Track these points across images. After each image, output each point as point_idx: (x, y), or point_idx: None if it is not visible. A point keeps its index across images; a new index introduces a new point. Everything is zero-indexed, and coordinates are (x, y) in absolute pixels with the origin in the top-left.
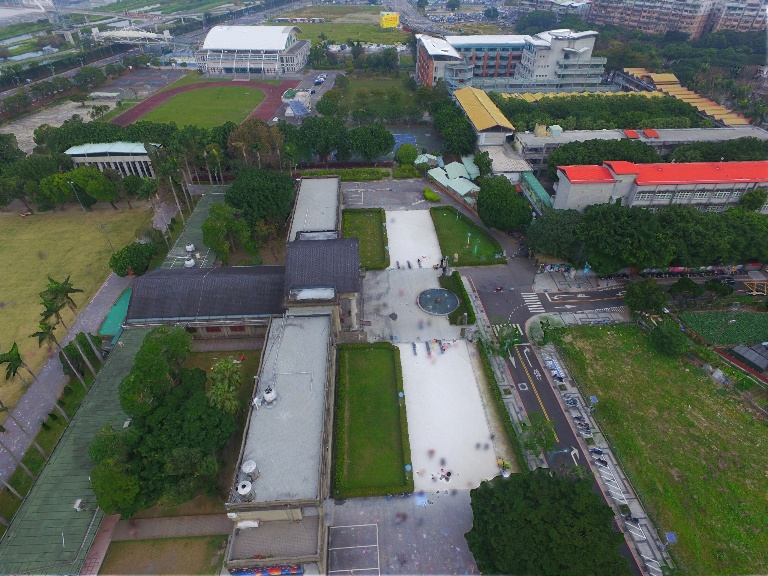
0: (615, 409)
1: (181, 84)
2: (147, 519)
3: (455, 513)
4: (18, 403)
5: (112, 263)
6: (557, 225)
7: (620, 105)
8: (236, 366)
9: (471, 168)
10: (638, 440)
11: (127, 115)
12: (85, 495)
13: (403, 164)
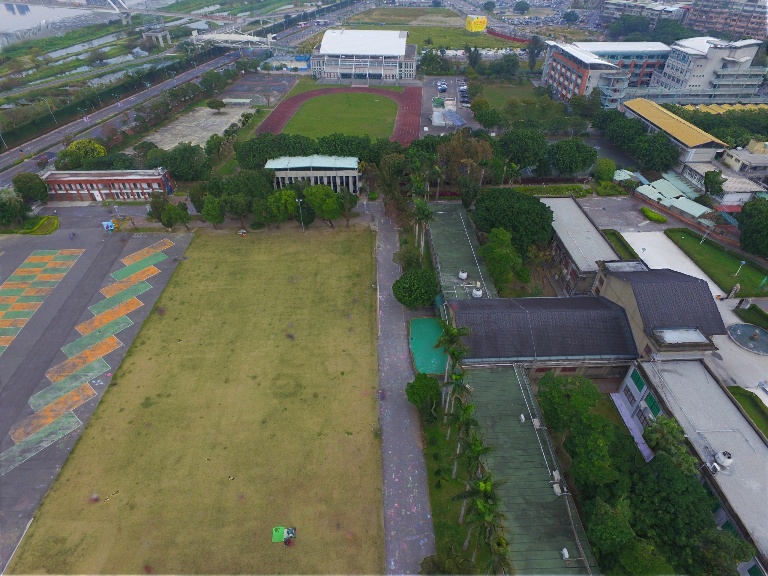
0: None
1: (302, 90)
2: None
3: None
4: (383, 454)
5: (403, 293)
6: None
7: None
8: None
9: (681, 186)
10: None
11: (269, 123)
12: (569, 575)
13: (602, 180)
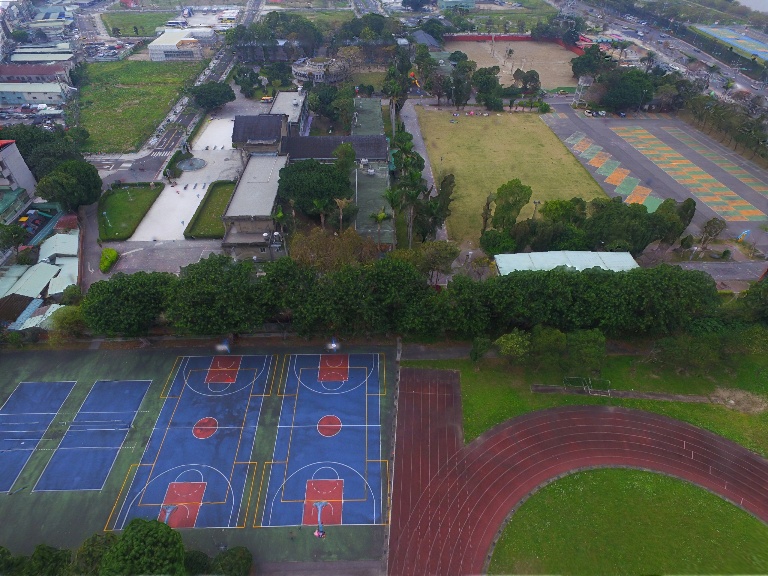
0: None
1: None
2: None
3: None
4: (422, 135)
5: None
6: None
7: None
8: (309, 101)
9: None
10: None
11: None
12: None
13: None
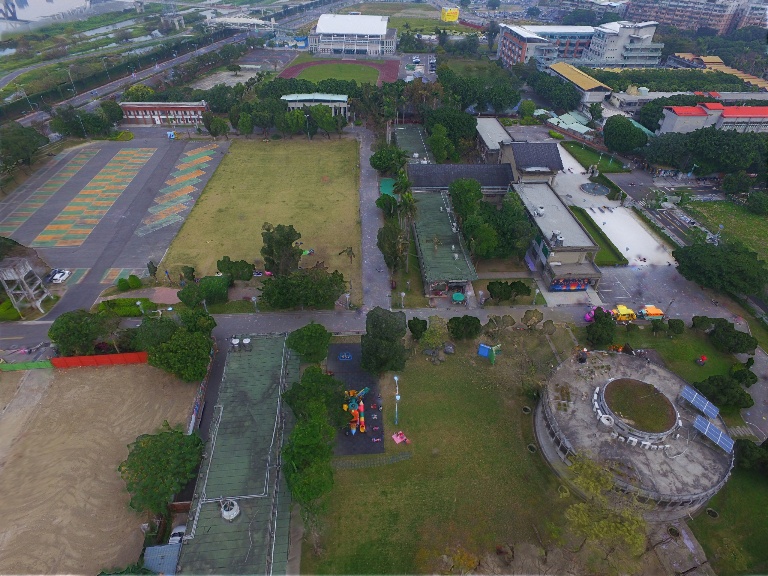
0: (732, 235)
1: (302, 61)
2: (483, 272)
3: (656, 273)
4: (362, 229)
5: (376, 160)
6: (673, 141)
7: (684, 76)
8: None
9: (580, 118)
10: (750, 248)
11: None
12: None
13: (525, 116)
